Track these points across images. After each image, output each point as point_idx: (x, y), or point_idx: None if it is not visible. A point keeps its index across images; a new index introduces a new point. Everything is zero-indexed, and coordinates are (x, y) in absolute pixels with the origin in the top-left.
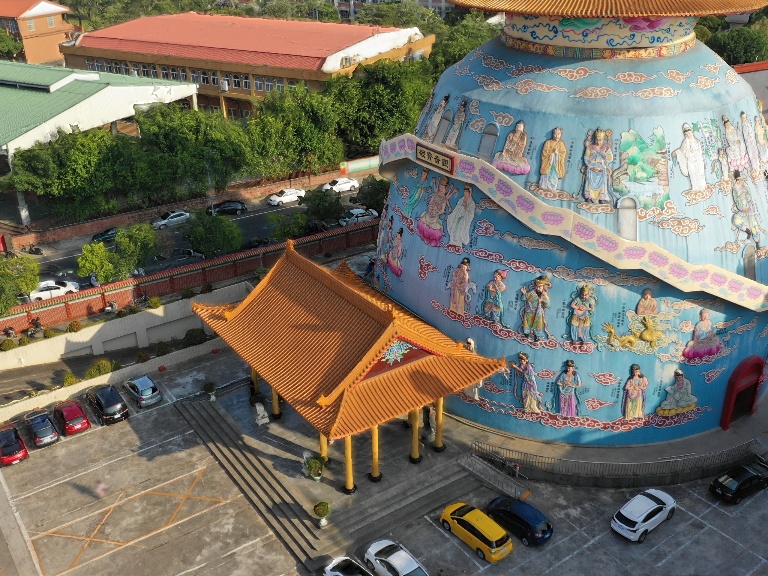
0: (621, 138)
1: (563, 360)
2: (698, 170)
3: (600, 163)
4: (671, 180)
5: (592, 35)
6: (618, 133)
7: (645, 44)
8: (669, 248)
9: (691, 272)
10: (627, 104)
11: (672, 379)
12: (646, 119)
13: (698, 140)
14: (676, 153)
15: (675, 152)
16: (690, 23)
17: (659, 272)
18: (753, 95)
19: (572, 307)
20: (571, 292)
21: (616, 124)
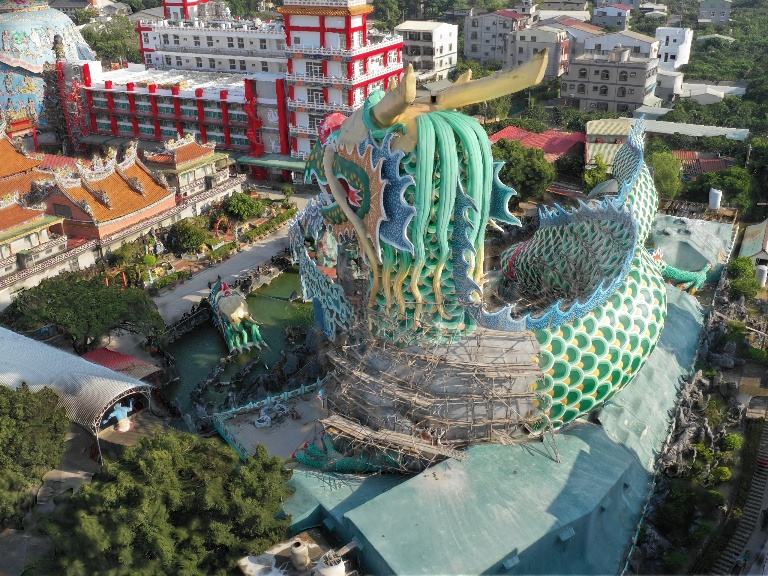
0: (12, 32)
1: (8, 98)
2: (38, 41)
3: (7, 40)
4: (29, 44)
5: (6, 6)
6: (11, 31)
7: (23, 8)
8: (31, 62)
9: (35, 67)
10: (14, 23)
11: (43, 103)
12: (19, 27)
13: (37, 33)
14: (30, 36)
15: (30, 36)
16: (41, 2)
17: (25, 67)
18: (65, 23)
19: (6, 81)
20: (5, 77)
21: (10, 29)
